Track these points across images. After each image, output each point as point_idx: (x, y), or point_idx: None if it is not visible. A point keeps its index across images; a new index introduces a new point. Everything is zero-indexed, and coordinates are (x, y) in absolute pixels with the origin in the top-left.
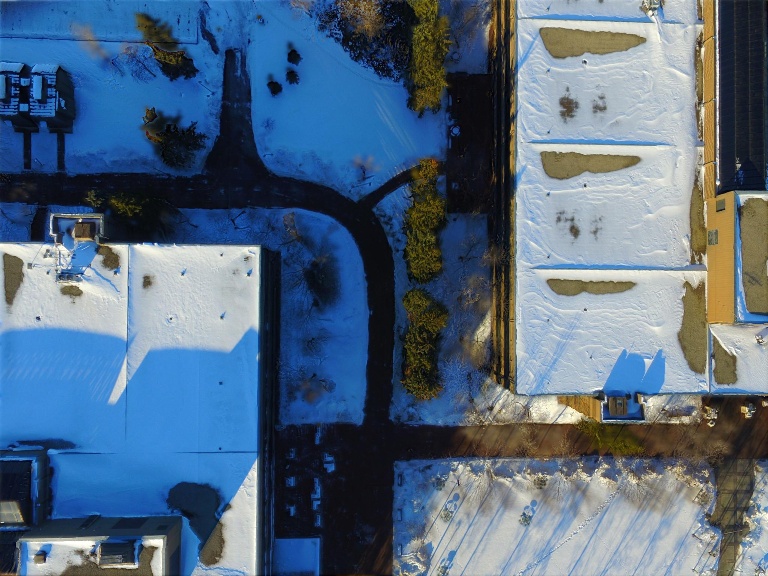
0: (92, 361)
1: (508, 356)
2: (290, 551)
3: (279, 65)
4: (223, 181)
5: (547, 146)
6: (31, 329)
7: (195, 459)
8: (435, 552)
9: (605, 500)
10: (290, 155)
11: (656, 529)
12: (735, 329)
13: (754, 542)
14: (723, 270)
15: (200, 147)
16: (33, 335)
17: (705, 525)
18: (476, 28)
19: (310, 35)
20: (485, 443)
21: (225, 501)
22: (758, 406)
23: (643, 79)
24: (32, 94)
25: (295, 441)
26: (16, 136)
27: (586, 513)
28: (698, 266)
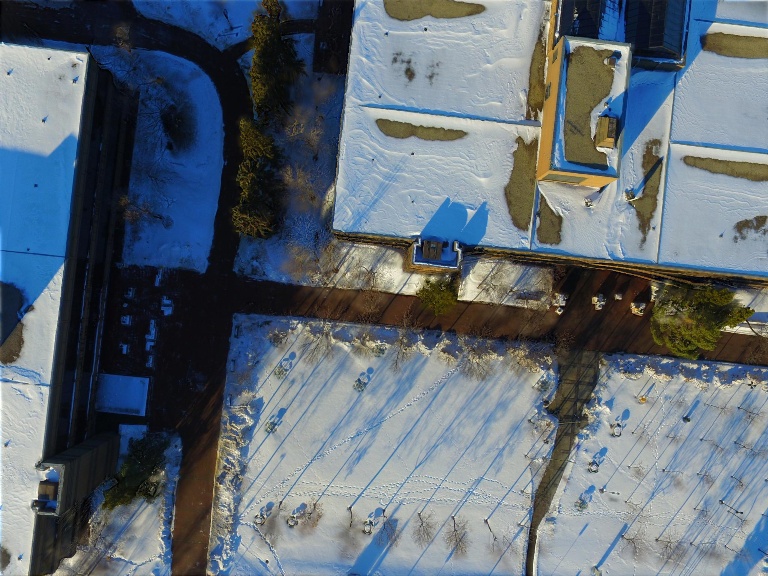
0: None
1: None
2: (118, 387)
3: None
4: (91, 17)
5: None
6: None
7: (2, 257)
8: (265, 407)
9: (443, 376)
10: None
11: (492, 410)
12: (564, 189)
13: (591, 434)
14: (549, 120)
15: None
16: None
17: (542, 412)
18: None
19: None
20: (327, 305)
21: (29, 302)
22: (610, 299)
23: None
24: None
25: (136, 281)
26: None
27: (422, 386)
28: (533, 122)
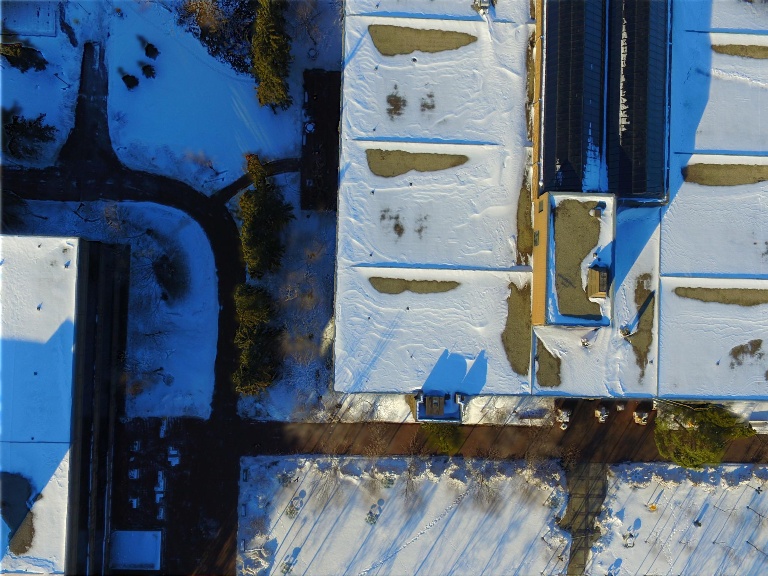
0: None
1: None
2: (131, 543)
3: (136, 59)
4: (76, 173)
5: (372, 144)
6: None
7: (7, 448)
8: (279, 548)
9: (454, 501)
10: (143, 149)
11: (505, 531)
12: (560, 331)
13: (604, 547)
14: (540, 271)
15: (49, 139)
16: None
17: (555, 529)
18: (333, 25)
19: (169, 30)
20: (333, 441)
21: (37, 491)
22: (613, 410)
23: (473, 78)
24: None
25: (141, 434)
26: None
27: (434, 513)
28: (524, 267)
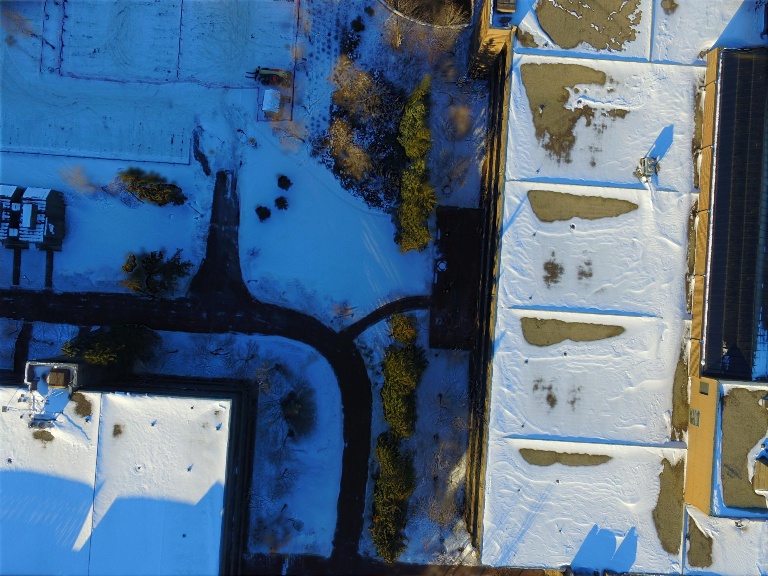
0: (59, 506)
1: (476, 520)
2: None
3: (269, 190)
4: (206, 305)
5: (528, 312)
6: (2, 471)
7: None
8: None
9: None
10: (274, 282)
11: None
12: None
13: None
14: (702, 457)
15: (184, 274)
16: (4, 477)
17: None
18: (469, 162)
19: (302, 160)
20: None
21: None
22: None
23: (632, 247)
24: (22, 219)
25: (262, 570)
26: (7, 252)
27: None
28: (678, 443)
